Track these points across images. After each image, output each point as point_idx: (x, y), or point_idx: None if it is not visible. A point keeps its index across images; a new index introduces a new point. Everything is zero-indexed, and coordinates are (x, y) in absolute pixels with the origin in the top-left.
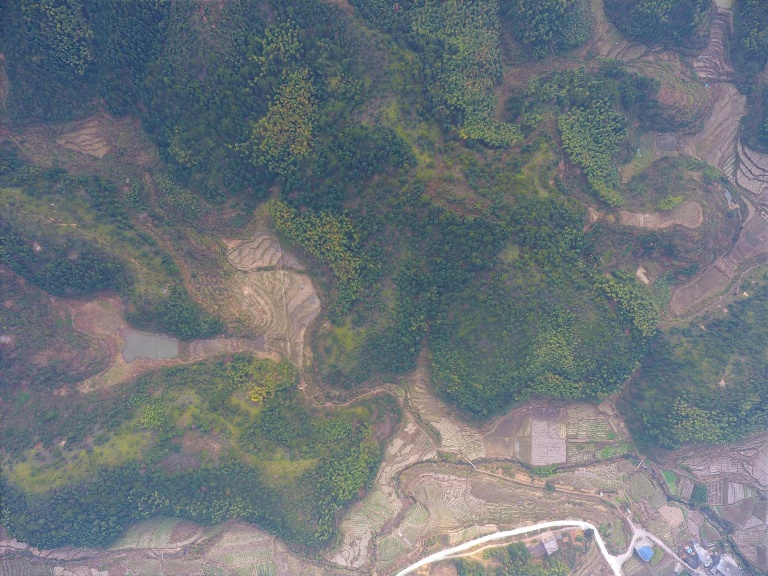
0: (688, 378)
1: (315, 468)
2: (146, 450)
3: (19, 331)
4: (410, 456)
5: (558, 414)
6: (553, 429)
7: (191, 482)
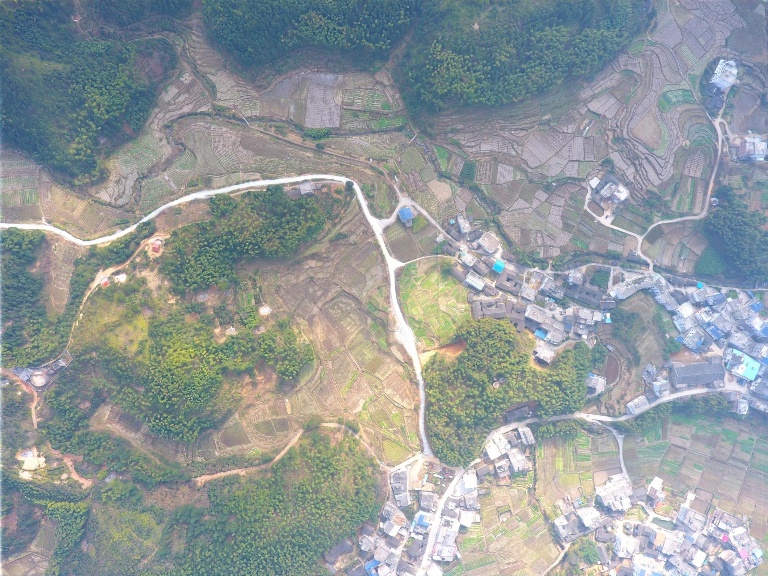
0: (448, 26)
1: (67, 72)
2: None
3: None
4: (184, 105)
5: (336, 80)
6: (329, 94)
7: None
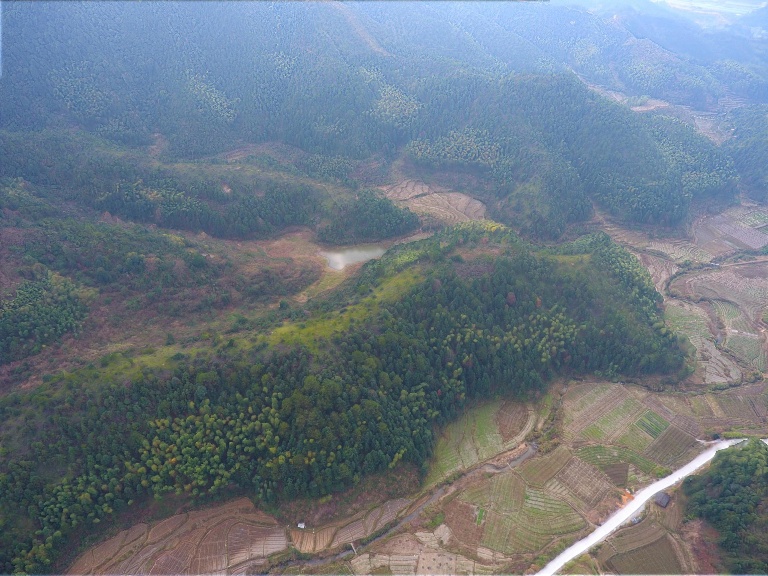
0: None
1: None
2: (427, 268)
3: (222, 248)
4: (660, 274)
5: (724, 217)
6: (735, 225)
7: (494, 294)
